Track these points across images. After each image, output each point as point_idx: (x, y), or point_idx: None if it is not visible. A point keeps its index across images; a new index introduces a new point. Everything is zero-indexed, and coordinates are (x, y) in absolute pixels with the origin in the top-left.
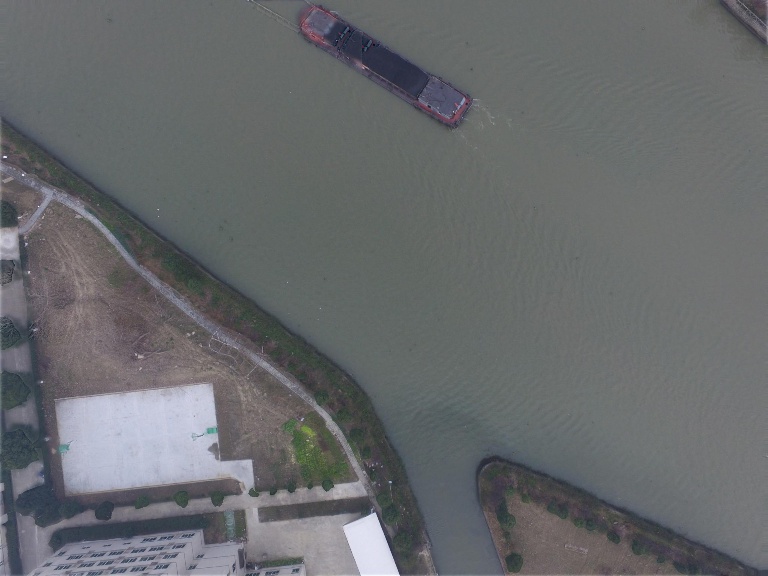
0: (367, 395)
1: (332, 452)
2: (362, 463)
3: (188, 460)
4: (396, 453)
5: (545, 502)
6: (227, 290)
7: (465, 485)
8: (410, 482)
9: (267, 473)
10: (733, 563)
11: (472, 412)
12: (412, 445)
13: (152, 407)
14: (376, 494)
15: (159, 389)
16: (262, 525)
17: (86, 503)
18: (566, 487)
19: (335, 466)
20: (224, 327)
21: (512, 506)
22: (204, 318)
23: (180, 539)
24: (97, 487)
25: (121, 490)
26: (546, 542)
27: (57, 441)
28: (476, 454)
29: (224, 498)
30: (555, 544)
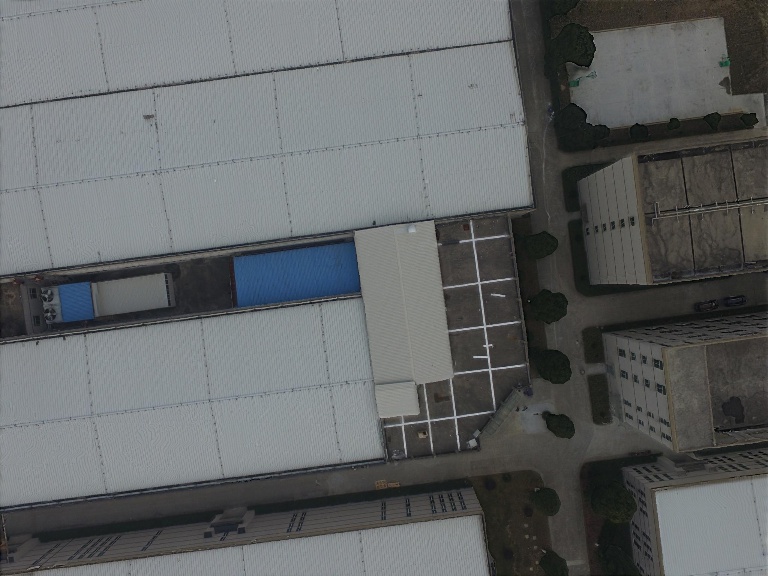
0: None
1: None
2: None
3: (699, 95)
4: None
5: None
6: None
7: None
8: None
9: None
10: None
11: None
12: None
13: (662, 42)
14: None
15: (669, 23)
16: None
17: None
18: None
19: None
20: None
21: None
22: None
23: None
24: (607, 124)
25: None
26: None
27: (566, 78)
28: None
29: (736, 133)
30: None
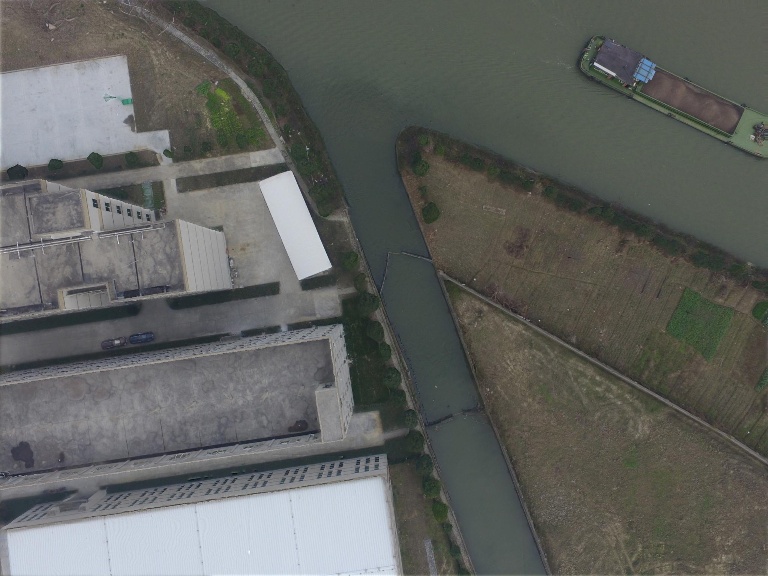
0: (283, 68)
1: (247, 116)
2: (278, 128)
3: (104, 133)
4: (313, 123)
5: (462, 162)
6: None
7: (385, 161)
8: (328, 151)
9: (183, 140)
10: (649, 218)
11: (388, 81)
12: (330, 117)
13: (66, 81)
14: (294, 160)
15: (73, 63)
16: (180, 196)
17: (2, 180)
18: (482, 148)
19: (251, 131)
20: None
21: (429, 167)
22: None
23: None
24: (13, 164)
25: (37, 166)
26: (464, 203)
27: None
28: (394, 127)
29: (141, 170)
30: (473, 205)
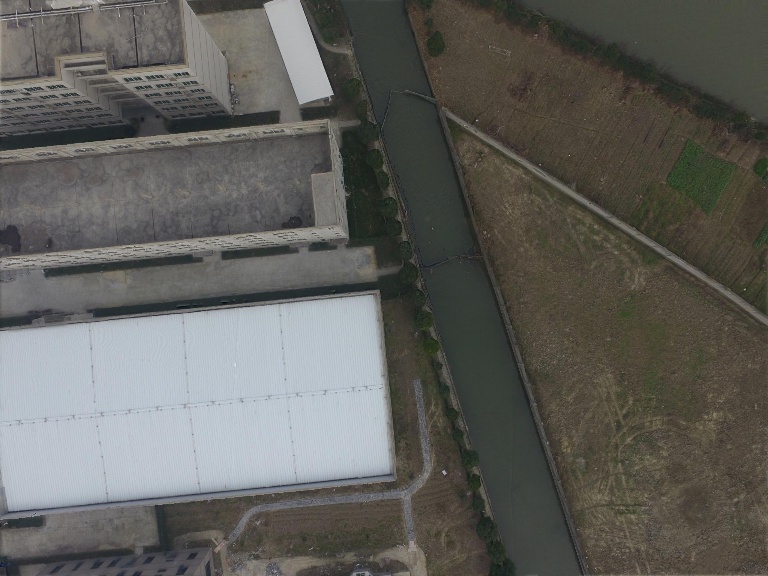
0: None
1: None
2: None
3: None
4: None
5: None
6: None
7: (392, 2)
8: None
9: None
10: (654, 67)
11: None
12: None
13: None
14: None
15: None
16: None
17: None
18: None
19: None
20: None
21: (436, 4)
22: None
23: None
24: None
25: None
26: (470, 42)
27: None
28: None
29: None
30: (479, 45)
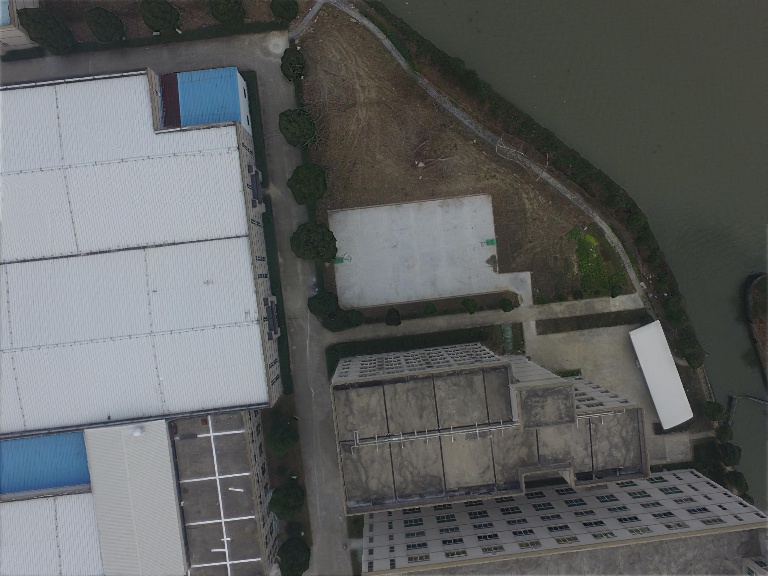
0: None
1: (613, 262)
2: (640, 274)
3: (466, 273)
4: (669, 267)
5: None
6: None
7: (727, 303)
8: (683, 296)
9: (548, 284)
10: None
11: (742, 228)
12: (683, 261)
13: (429, 219)
14: (653, 306)
15: (436, 200)
16: (540, 338)
17: None
18: None
19: (615, 276)
20: (509, 134)
21: None
22: (483, 128)
23: (468, 346)
24: (372, 301)
25: (397, 304)
26: None
27: None
28: (742, 271)
29: (502, 311)
30: None
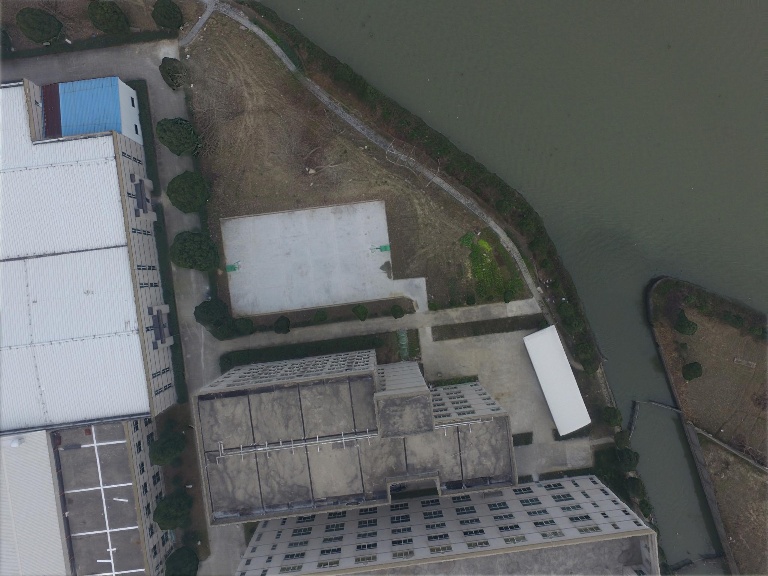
0: None
1: (508, 267)
2: (537, 279)
3: (360, 279)
4: None
5: (716, 316)
6: (398, 105)
7: (631, 307)
8: (582, 300)
9: (442, 289)
10: None
11: (642, 231)
12: (582, 265)
13: (322, 225)
14: (550, 311)
15: (329, 207)
16: (436, 344)
17: (255, 325)
18: (736, 302)
19: (511, 282)
20: None
21: None
22: (375, 133)
23: None
24: (266, 308)
25: (291, 311)
26: (716, 356)
27: (223, 262)
28: (644, 274)
29: None
30: (725, 358)
